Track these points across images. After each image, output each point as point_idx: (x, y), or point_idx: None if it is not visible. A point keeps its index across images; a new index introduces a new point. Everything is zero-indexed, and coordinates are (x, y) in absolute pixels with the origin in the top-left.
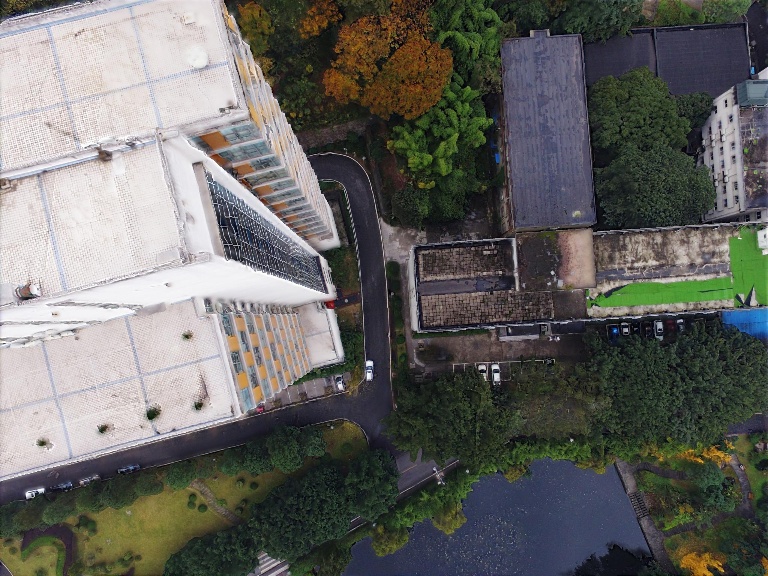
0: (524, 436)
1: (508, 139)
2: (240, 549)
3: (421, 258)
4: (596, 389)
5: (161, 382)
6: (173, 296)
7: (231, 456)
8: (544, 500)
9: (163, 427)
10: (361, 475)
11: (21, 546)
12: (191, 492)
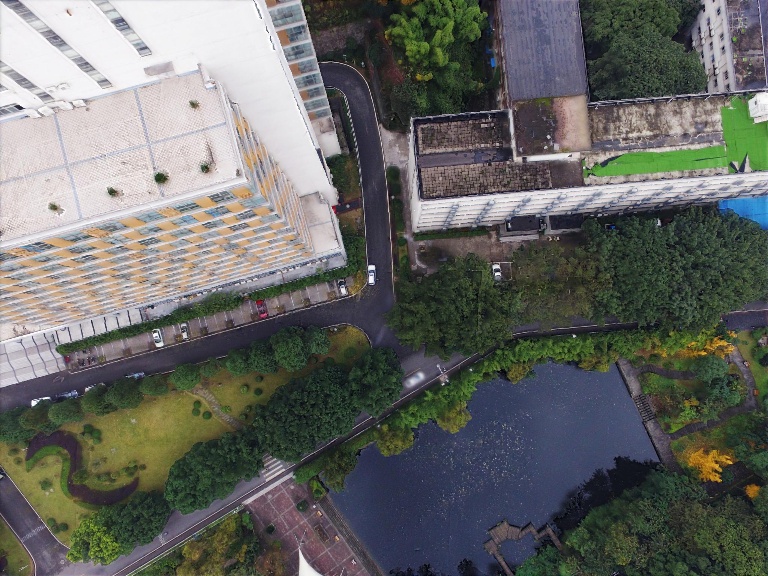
0: (527, 336)
1: (502, 32)
2: (245, 447)
3: (420, 132)
4: (596, 270)
5: (169, 149)
6: (181, 47)
7: (235, 353)
8: (549, 405)
9: (170, 192)
10: (365, 368)
11: (26, 456)
12: (195, 399)
